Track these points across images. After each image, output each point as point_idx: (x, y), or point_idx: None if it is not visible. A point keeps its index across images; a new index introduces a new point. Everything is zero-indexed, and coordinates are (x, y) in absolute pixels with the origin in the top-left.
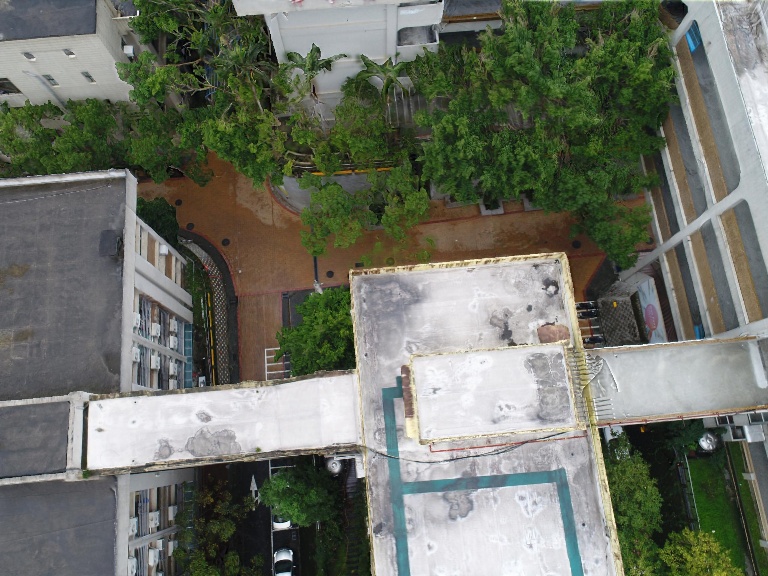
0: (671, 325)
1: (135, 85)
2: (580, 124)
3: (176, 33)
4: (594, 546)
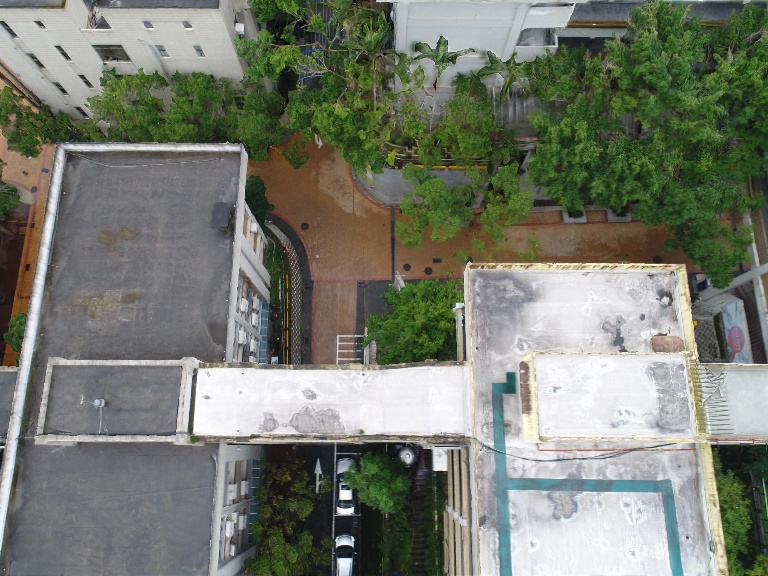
0: (760, 349)
1: (251, 62)
2: (703, 138)
3: (295, 15)
4: (697, 560)
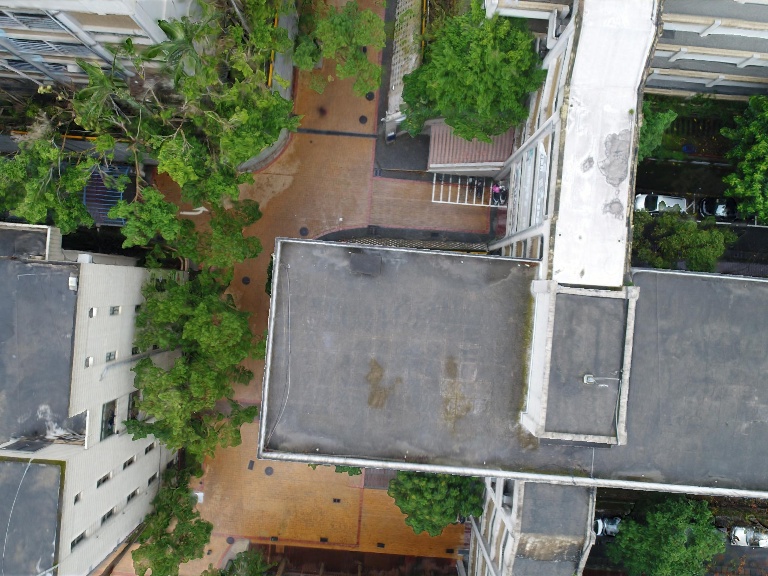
0: None
1: (155, 231)
2: None
3: None
4: None
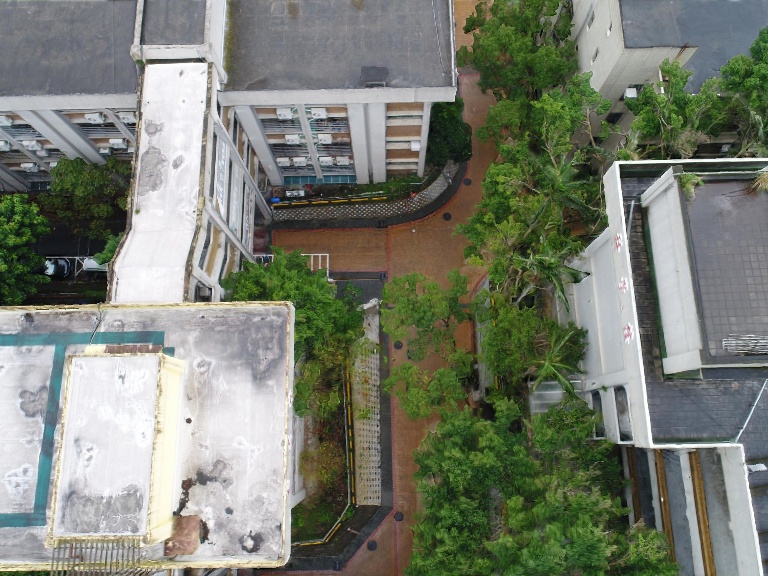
0: None
1: (567, 94)
2: None
3: None
4: None
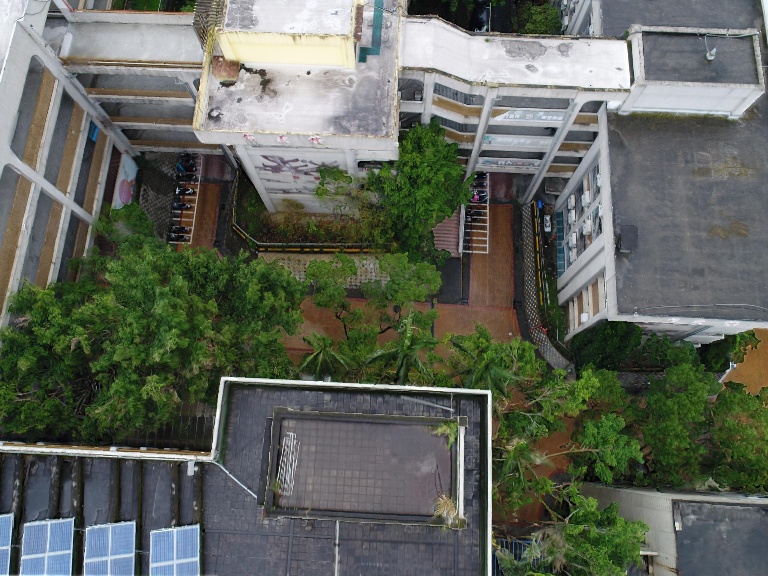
0: (113, 166)
1: (619, 435)
2: None
3: None
4: None
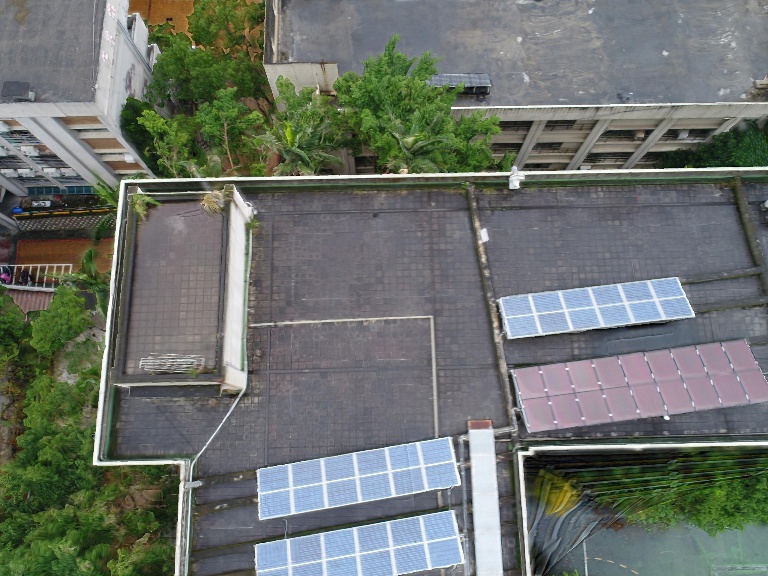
0: None
1: None
2: None
3: None
4: None
